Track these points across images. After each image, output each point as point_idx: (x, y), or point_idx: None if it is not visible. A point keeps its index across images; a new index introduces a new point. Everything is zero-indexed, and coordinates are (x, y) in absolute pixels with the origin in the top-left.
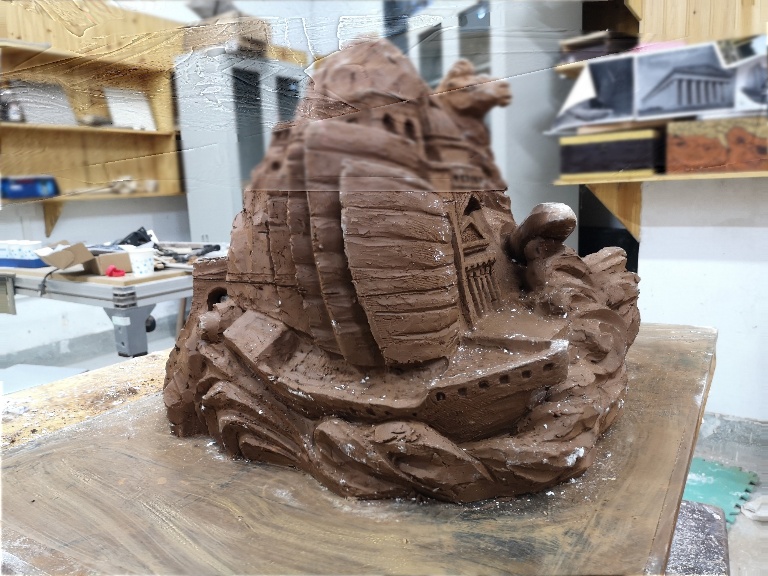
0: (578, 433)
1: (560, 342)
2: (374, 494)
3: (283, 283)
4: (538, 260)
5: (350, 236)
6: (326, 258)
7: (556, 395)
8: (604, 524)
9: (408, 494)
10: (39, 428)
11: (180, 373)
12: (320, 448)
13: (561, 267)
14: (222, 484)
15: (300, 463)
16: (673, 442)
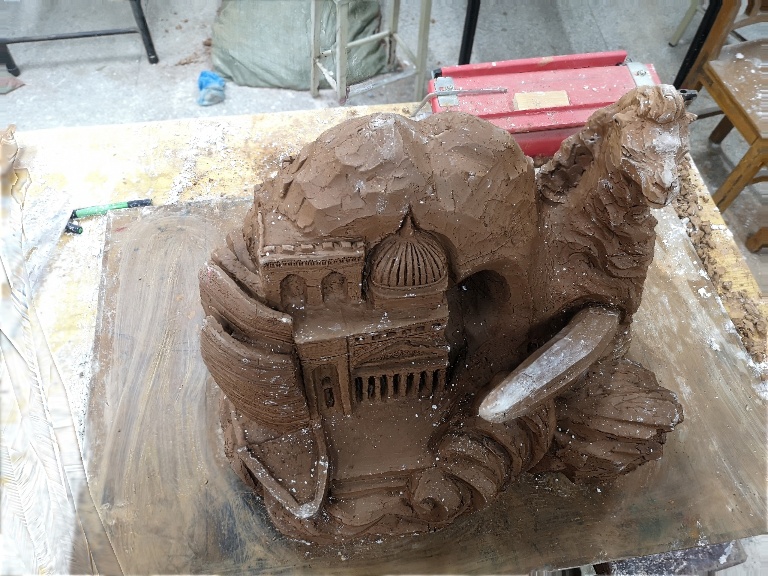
0: None
1: (308, 510)
2: None
3: None
4: None
5: None
6: None
7: None
8: None
9: None
10: (216, 177)
11: None
12: None
13: None
14: None
15: None
16: None
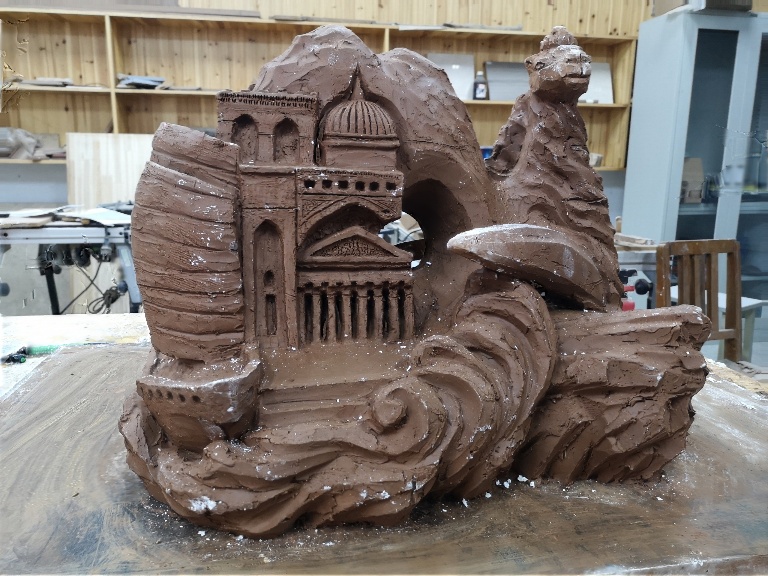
0: (230, 486)
1: (222, 379)
2: None
3: None
4: (465, 295)
5: (133, 229)
6: None
7: (248, 439)
8: None
9: None
10: None
11: None
12: None
13: (493, 311)
14: None
15: None
16: None
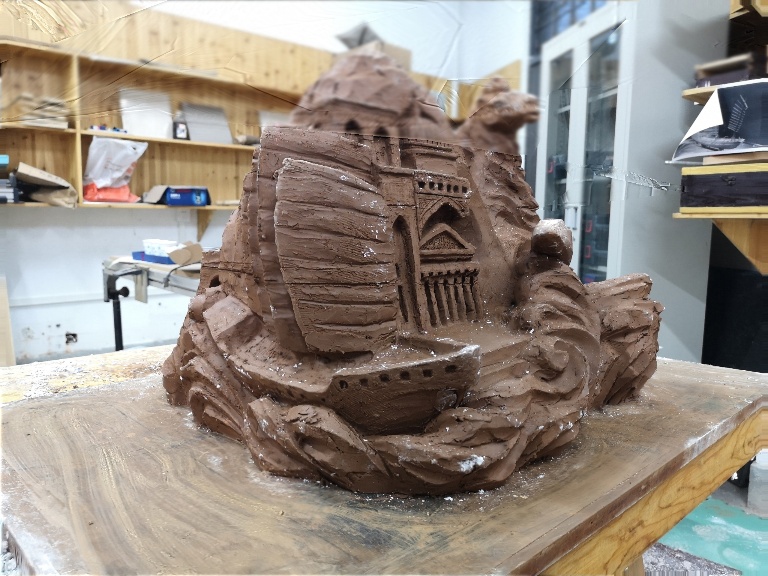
0: (484, 442)
1: (470, 346)
2: (283, 471)
3: (249, 271)
4: (527, 275)
5: (280, 227)
6: (268, 247)
7: (473, 402)
8: (477, 533)
9: (314, 476)
10: (81, 385)
11: (178, 348)
12: (249, 422)
13: (552, 285)
14: (174, 445)
15: (243, 437)
16: (621, 475)
